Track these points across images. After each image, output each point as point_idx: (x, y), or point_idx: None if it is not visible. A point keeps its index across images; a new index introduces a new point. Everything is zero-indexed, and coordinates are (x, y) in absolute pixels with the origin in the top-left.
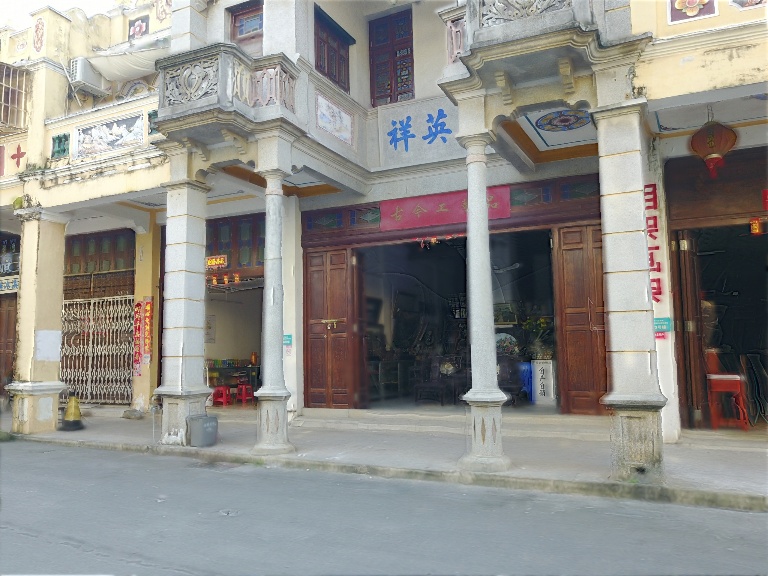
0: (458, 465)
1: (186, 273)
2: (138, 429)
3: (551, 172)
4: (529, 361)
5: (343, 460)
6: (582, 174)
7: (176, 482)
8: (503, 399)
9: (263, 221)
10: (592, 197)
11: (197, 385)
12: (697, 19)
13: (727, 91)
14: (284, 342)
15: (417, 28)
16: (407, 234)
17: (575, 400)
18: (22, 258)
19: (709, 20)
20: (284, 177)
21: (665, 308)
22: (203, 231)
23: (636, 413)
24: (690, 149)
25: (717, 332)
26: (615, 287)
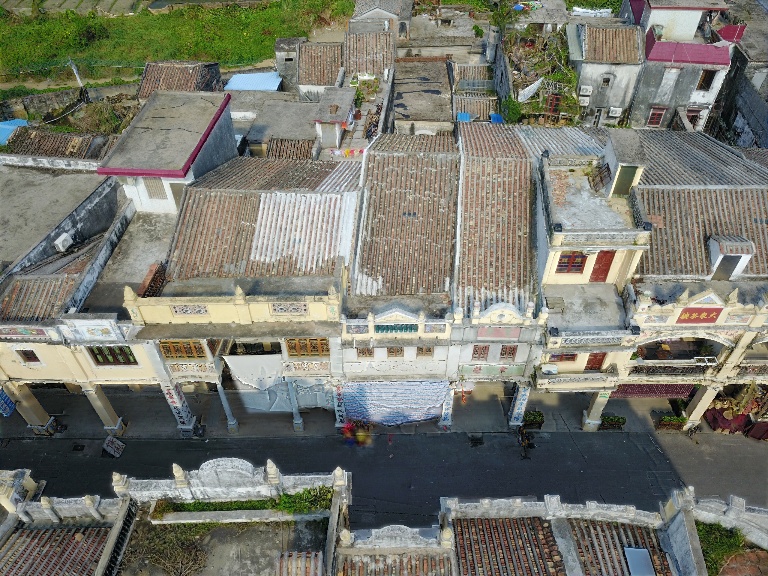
0: None
1: None
2: None
3: None
4: None
5: None
6: None
7: None
8: None
9: None
10: None
11: None
12: None
13: None
14: None
15: None
16: None
17: None
18: None
19: None
20: None
21: None
22: None
23: None
24: None
25: None
26: None
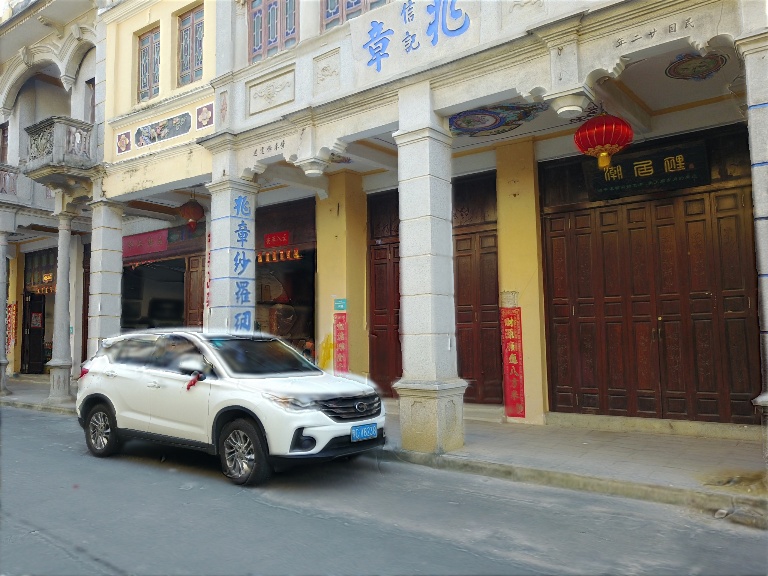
0: None
1: None
2: None
3: (182, 221)
4: None
5: None
6: None
7: None
8: (63, 364)
9: None
10: (200, 237)
11: None
12: (123, 153)
13: (133, 194)
14: None
15: None
16: (125, 261)
17: None
18: None
19: (128, 154)
20: (8, 234)
21: None
22: None
23: None
24: None
25: (290, 325)
26: (92, 303)
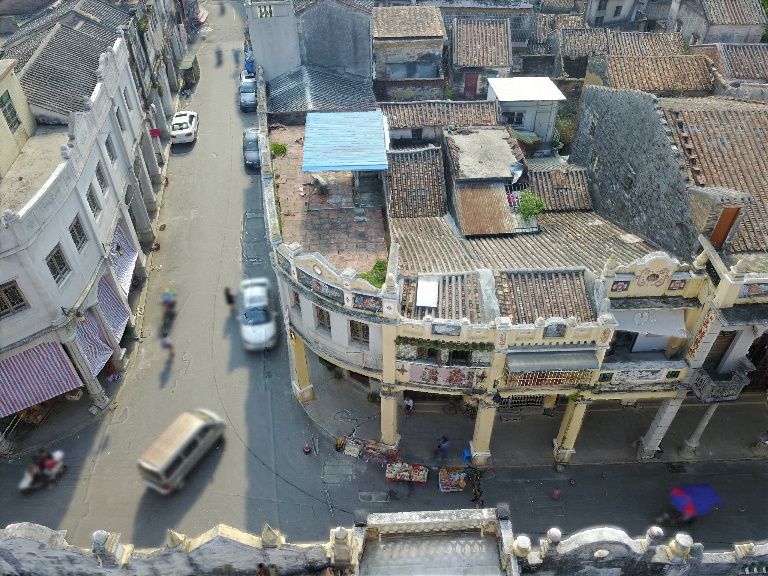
0: (755, 454)
1: None
2: (590, 436)
3: None
4: None
5: (713, 454)
6: None
7: (696, 491)
8: None
9: None
10: None
11: None
12: None
13: None
14: None
15: None
16: None
17: None
18: (573, 415)
19: None
20: None
21: None
22: None
23: None
24: None
25: None
26: None
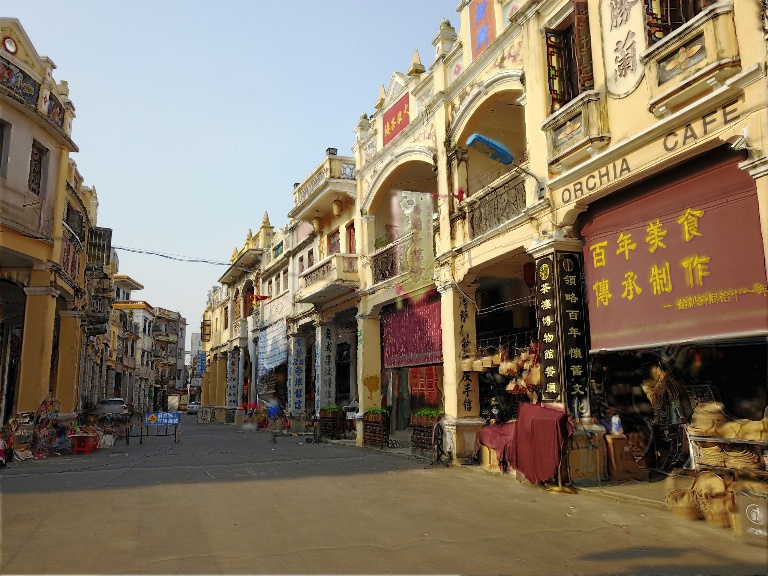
0: None
1: None
2: None
3: None
4: None
5: None
6: None
7: None
8: None
9: (2, 328)
10: None
11: None
12: None
13: None
14: None
15: None
16: None
17: None
18: None
19: None
20: None
21: None
22: None
23: None
24: None
25: None
26: None
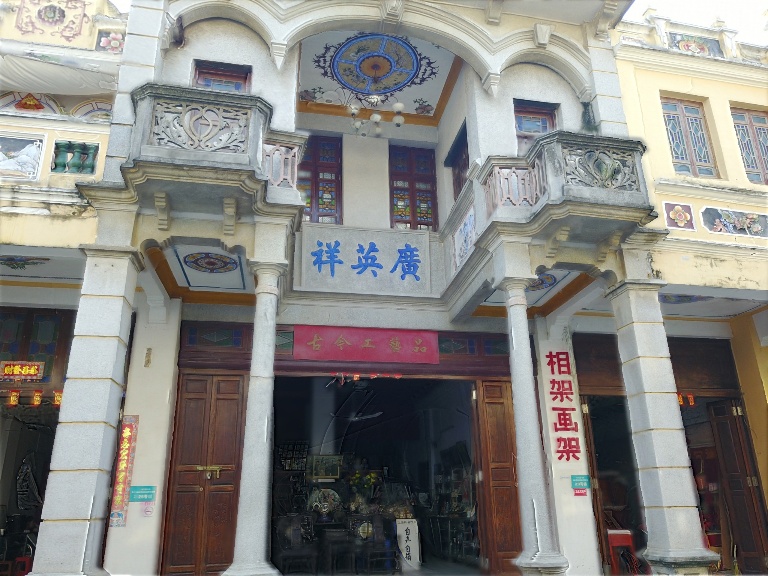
0: None
1: (112, 383)
2: None
3: (478, 326)
4: (395, 520)
5: None
6: (504, 333)
7: None
8: None
9: None
10: None
11: (99, 569)
12: (686, 230)
13: (709, 289)
14: (143, 497)
15: (348, 158)
16: (327, 367)
17: (504, 562)
18: None
19: (692, 233)
20: (280, 275)
21: (584, 466)
22: (129, 324)
23: (695, 570)
24: (587, 327)
25: None
26: (662, 443)
